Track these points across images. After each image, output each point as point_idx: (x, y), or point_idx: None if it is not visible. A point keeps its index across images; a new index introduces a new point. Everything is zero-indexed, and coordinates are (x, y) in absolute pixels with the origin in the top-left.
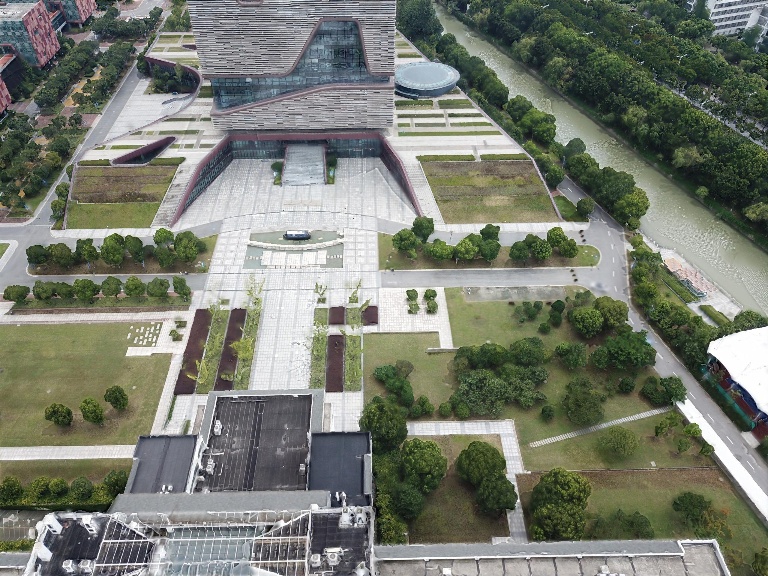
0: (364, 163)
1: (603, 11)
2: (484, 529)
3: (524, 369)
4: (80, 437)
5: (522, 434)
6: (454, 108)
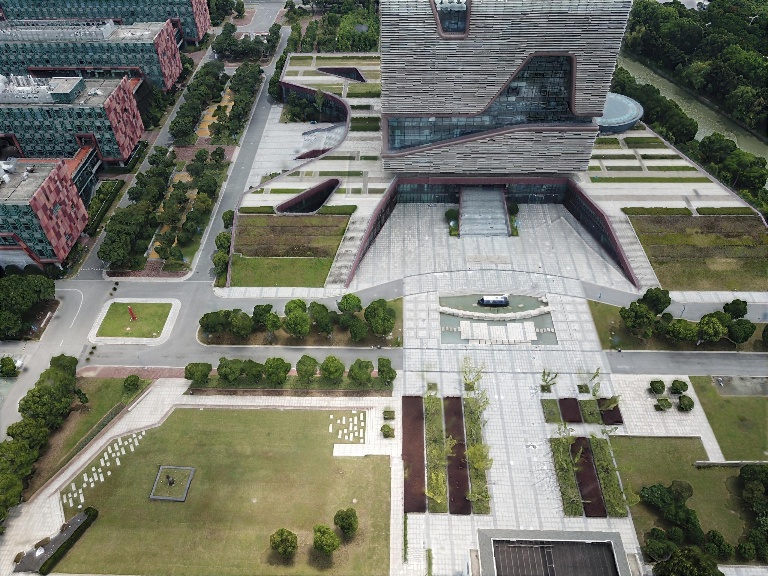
0: (546, 210)
1: None
2: None
3: None
4: (307, 569)
5: None
6: (645, 148)
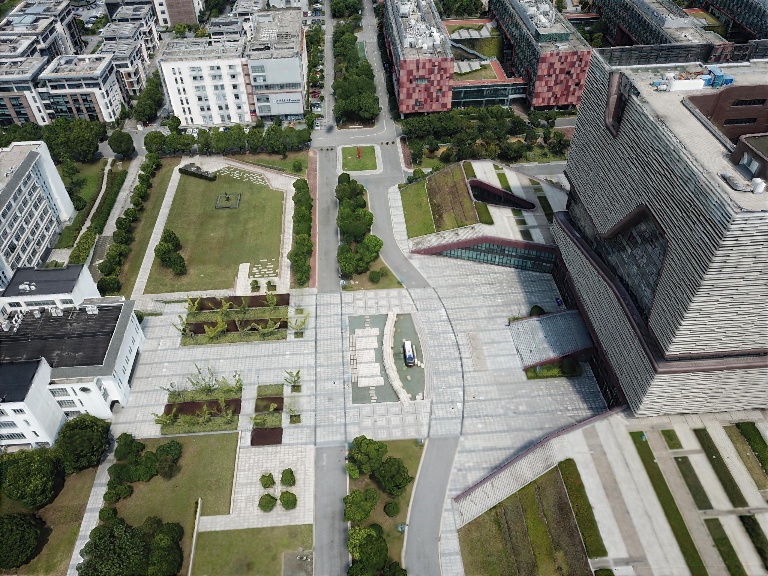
0: (594, 411)
1: None
2: None
3: None
4: None
5: None
6: None
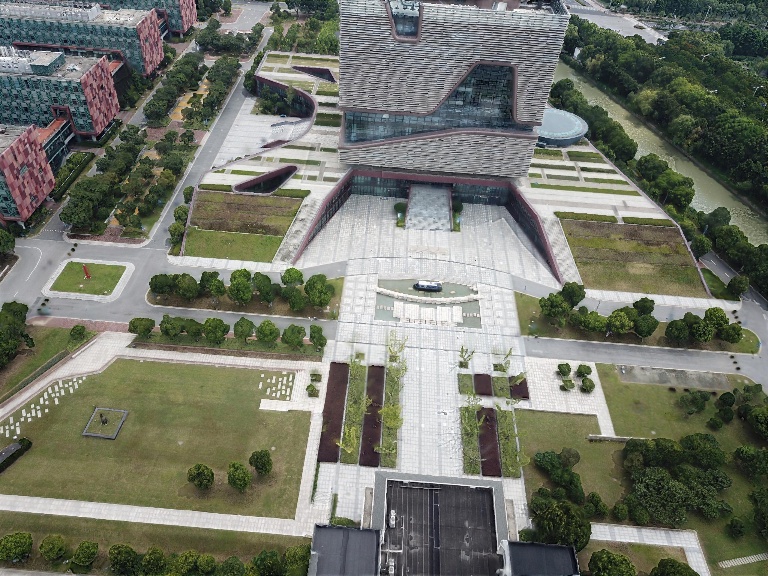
0: (489, 211)
1: (721, 68)
2: None
3: (704, 472)
4: (220, 503)
5: (708, 550)
6: (585, 161)
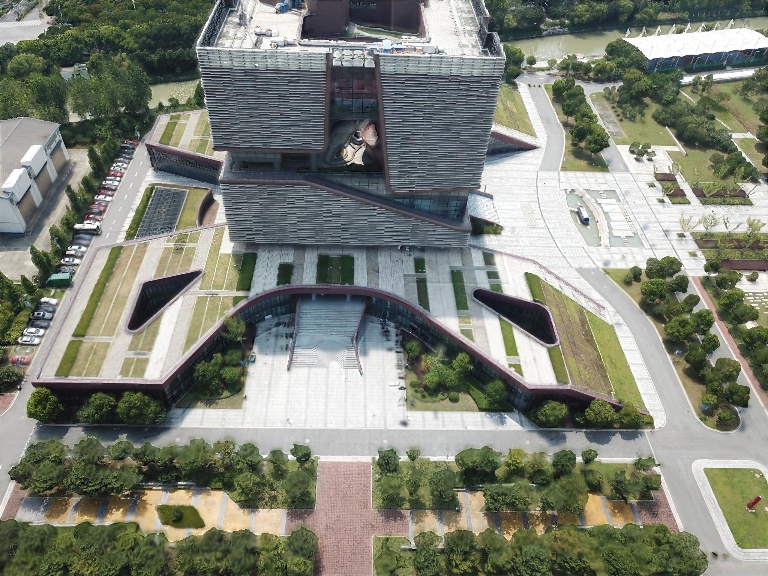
0: None
1: (156, 4)
2: None
3: None
4: None
5: None
6: None
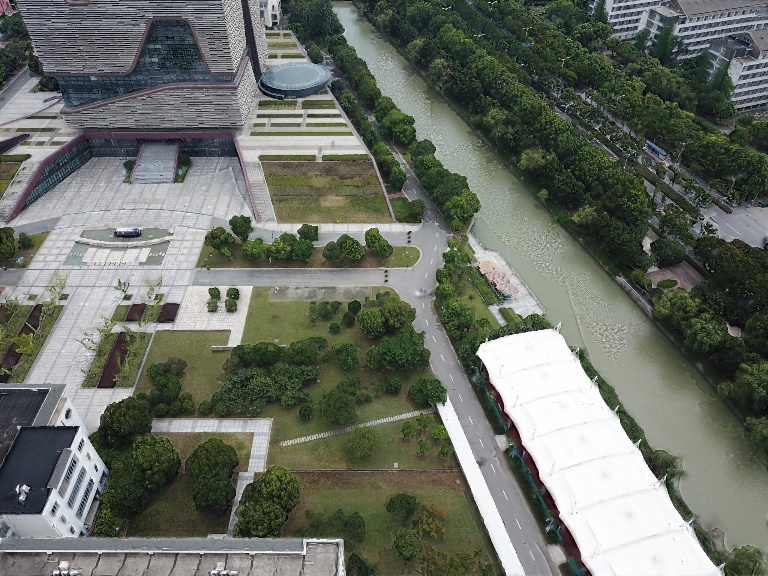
0: (220, 162)
1: (506, 13)
2: (203, 526)
3: (294, 368)
4: None
5: (276, 433)
6: (316, 108)
